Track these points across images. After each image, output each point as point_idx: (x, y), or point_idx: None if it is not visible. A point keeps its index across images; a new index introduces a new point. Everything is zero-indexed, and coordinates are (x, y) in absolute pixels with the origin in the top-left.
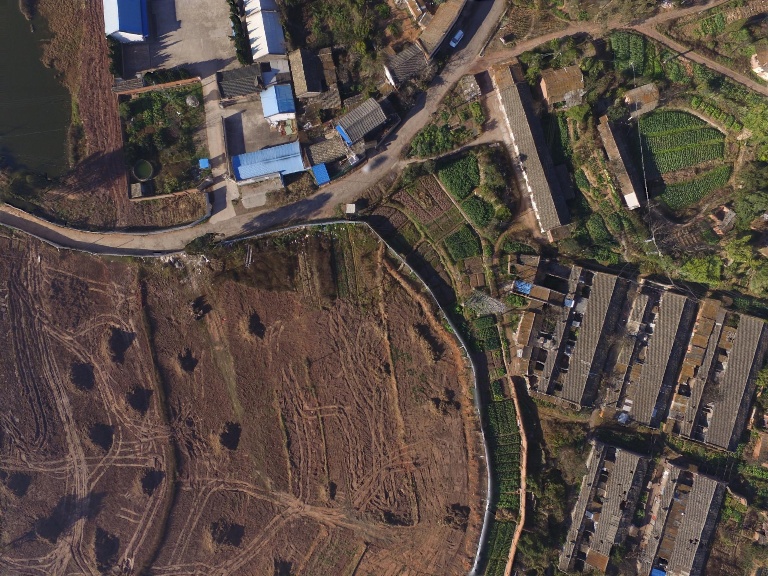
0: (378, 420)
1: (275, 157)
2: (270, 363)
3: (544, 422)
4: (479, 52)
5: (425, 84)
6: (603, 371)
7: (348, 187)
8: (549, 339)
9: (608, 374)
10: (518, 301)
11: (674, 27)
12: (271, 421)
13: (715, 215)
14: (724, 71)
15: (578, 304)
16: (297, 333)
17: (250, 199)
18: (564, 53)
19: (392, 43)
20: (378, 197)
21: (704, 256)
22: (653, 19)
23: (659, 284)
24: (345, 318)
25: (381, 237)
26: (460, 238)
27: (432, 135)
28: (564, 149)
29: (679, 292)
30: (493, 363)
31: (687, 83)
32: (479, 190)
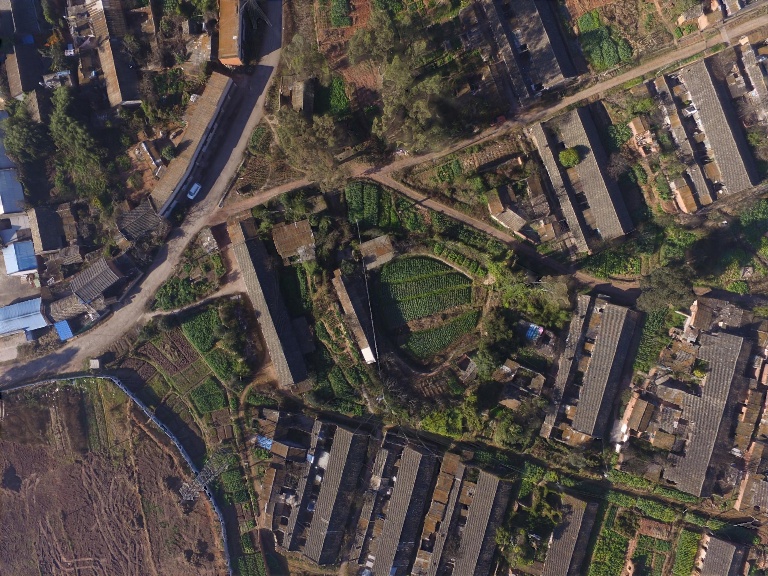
0: (134, 572)
1: (17, 315)
2: (28, 515)
3: (294, 575)
4: (218, 203)
5: (161, 239)
6: (345, 527)
7: (95, 340)
8: (292, 494)
9: (349, 531)
10: (264, 454)
11: (410, 175)
12: (31, 572)
13: (457, 365)
14: (463, 218)
15: (320, 458)
16: (52, 486)
17: (2, 353)
18: (294, 207)
19: (134, 194)
20: (125, 350)
21: (444, 409)
22: (389, 167)
23: (402, 437)
24: (97, 471)
25: (130, 390)
26: (206, 391)
27: (175, 288)
28: (303, 301)
29: (416, 448)
30: (243, 515)
31: (425, 232)
32: (220, 344)
